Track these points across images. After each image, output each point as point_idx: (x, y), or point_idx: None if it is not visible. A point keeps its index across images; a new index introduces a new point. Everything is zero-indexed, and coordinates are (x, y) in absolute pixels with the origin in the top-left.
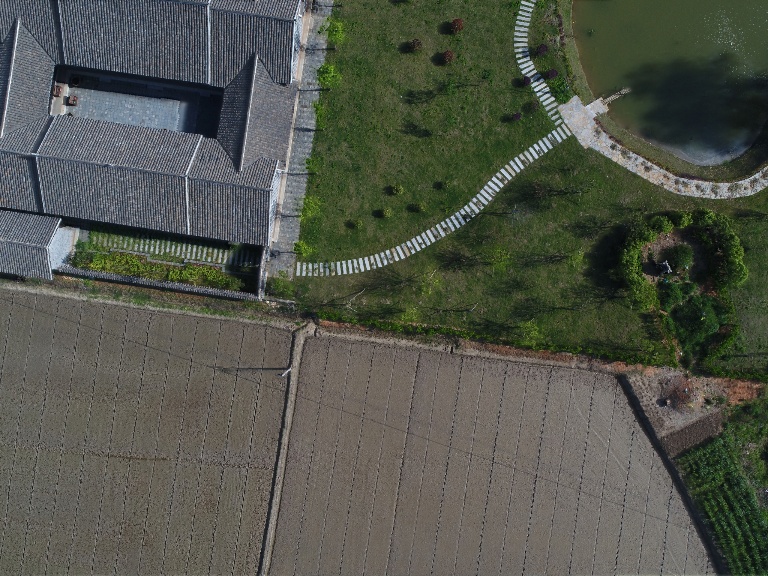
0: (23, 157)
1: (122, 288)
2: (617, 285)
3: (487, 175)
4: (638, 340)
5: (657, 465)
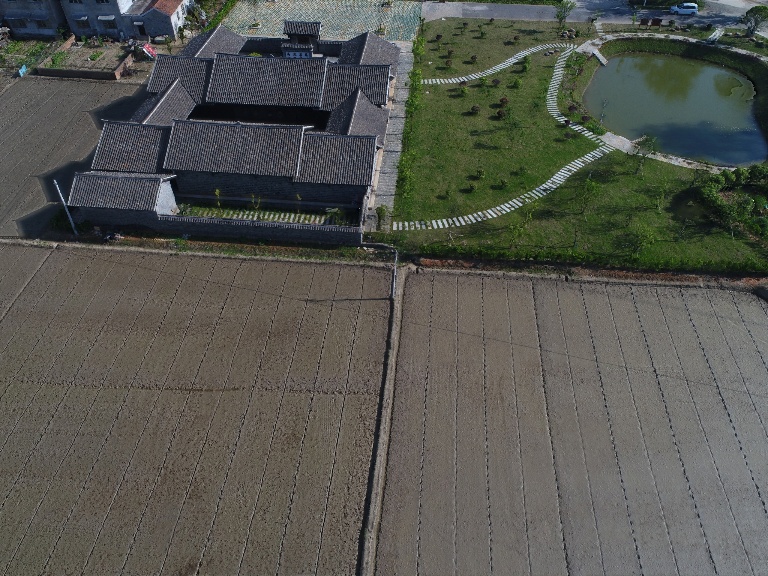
0: (159, 129)
1: (214, 245)
2: (709, 226)
3: (555, 168)
4: (756, 260)
5: None
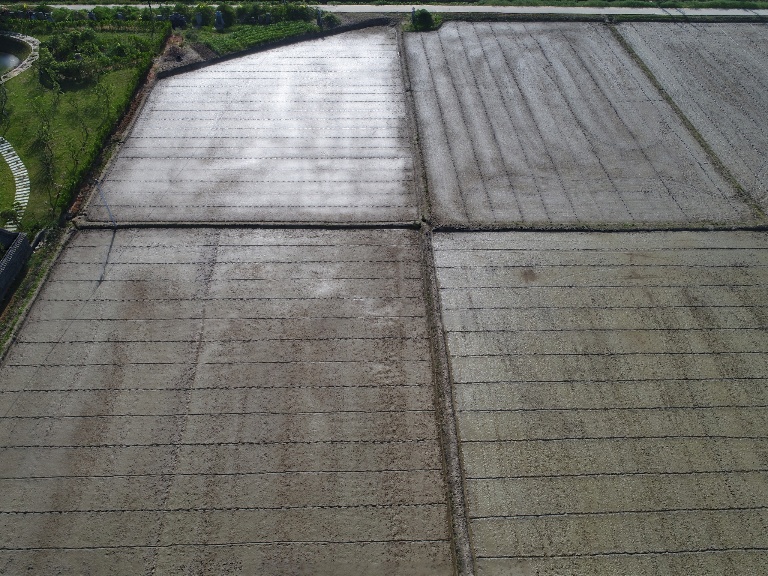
0: None
1: None
2: (89, 81)
3: None
4: None
5: (226, 63)
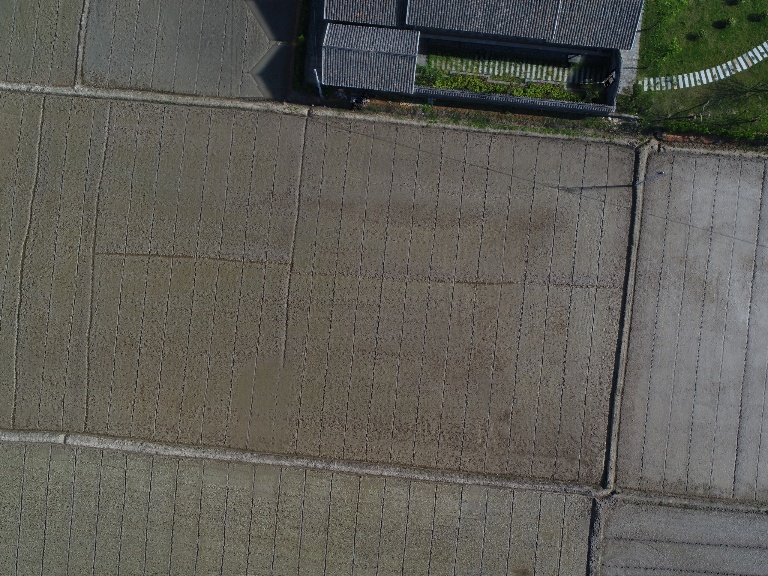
0: None
1: (461, 112)
2: None
3: None
4: None
5: None
